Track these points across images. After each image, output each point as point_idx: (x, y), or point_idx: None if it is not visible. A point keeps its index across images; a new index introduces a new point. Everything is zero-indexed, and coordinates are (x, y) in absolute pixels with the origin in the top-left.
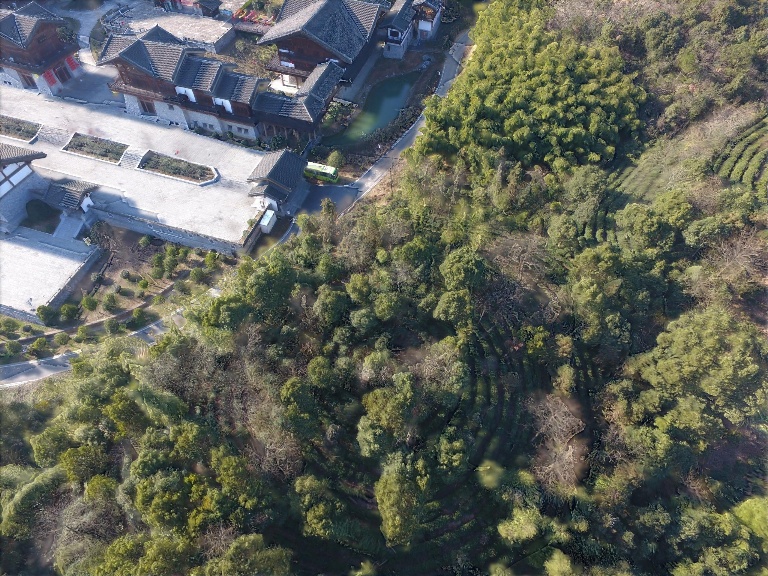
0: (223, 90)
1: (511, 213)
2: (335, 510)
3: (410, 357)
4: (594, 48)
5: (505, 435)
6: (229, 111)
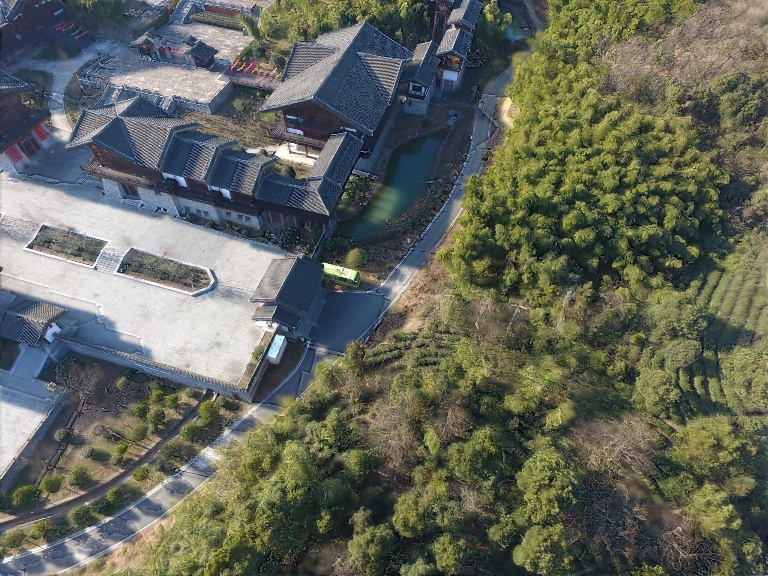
0: (220, 177)
1: (578, 340)
2: None
3: None
4: (662, 118)
5: None
6: (227, 197)
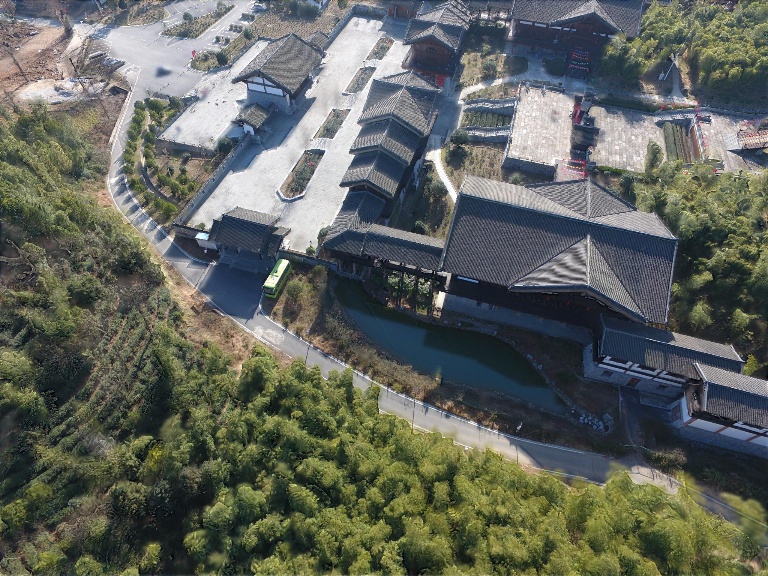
0: (359, 161)
1: None
2: None
3: None
4: None
5: None
6: None
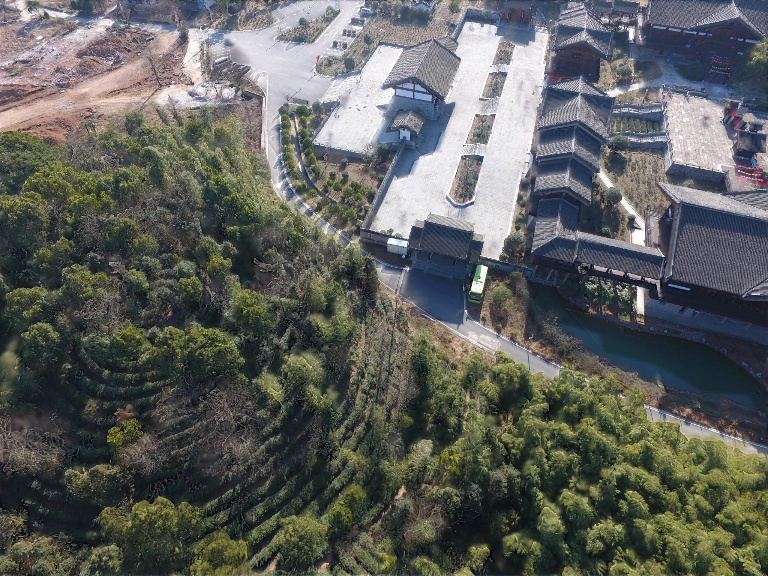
0: (547, 168)
1: None
2: (42, 263)
3: (155, 323)
4: None
5: (68, 417)
6: None
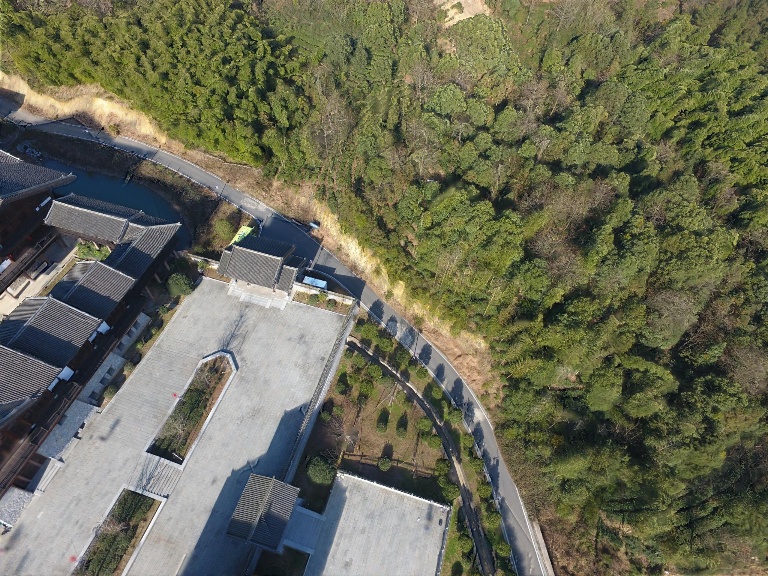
0: (95, 310)
1: None
2: None
3: None
4: None
5: None
6: (106, 331)
